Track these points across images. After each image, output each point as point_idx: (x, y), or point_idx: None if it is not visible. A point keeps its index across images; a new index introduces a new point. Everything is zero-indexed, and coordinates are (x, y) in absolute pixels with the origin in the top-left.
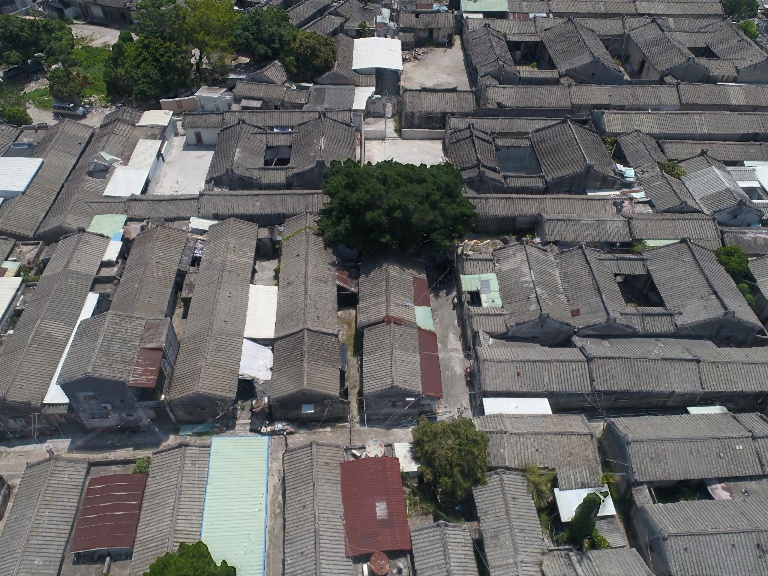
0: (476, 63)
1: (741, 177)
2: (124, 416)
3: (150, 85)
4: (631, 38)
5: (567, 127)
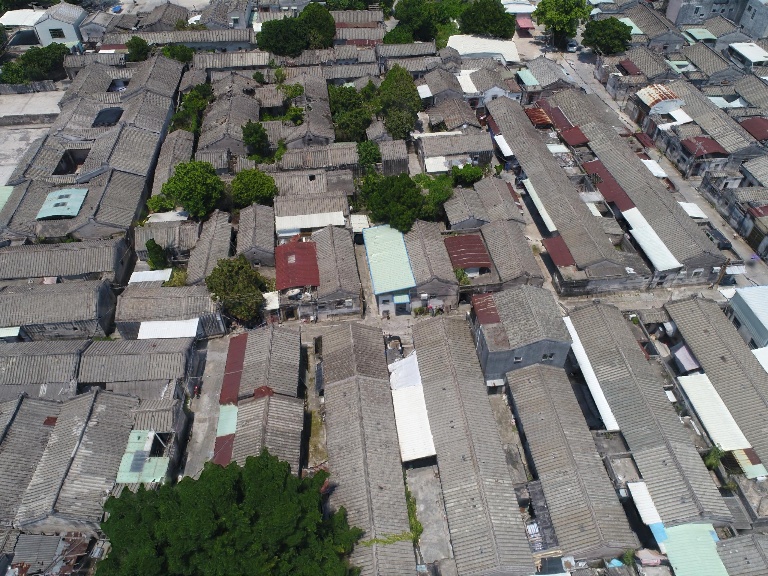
0: None
1: None
2: None
3: None
4: None
5: None
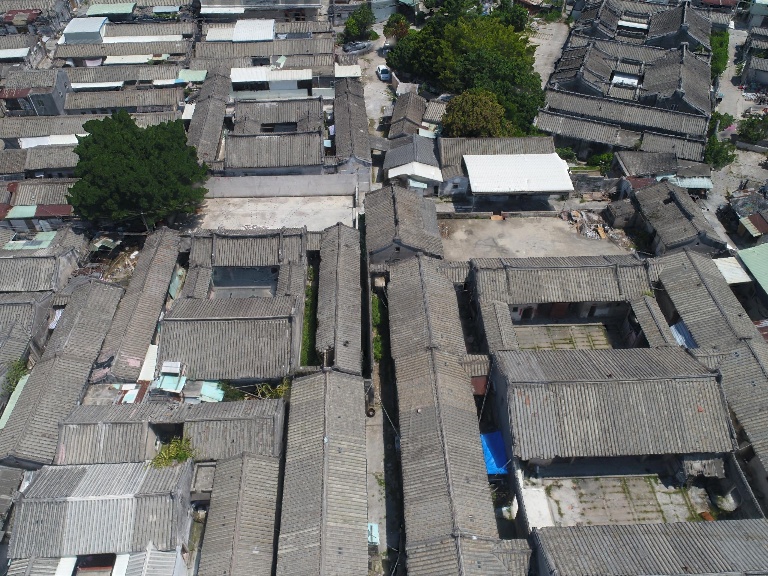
0: None
1: (131, 573)
2: None
3: (397, 57)
4: None
5: None
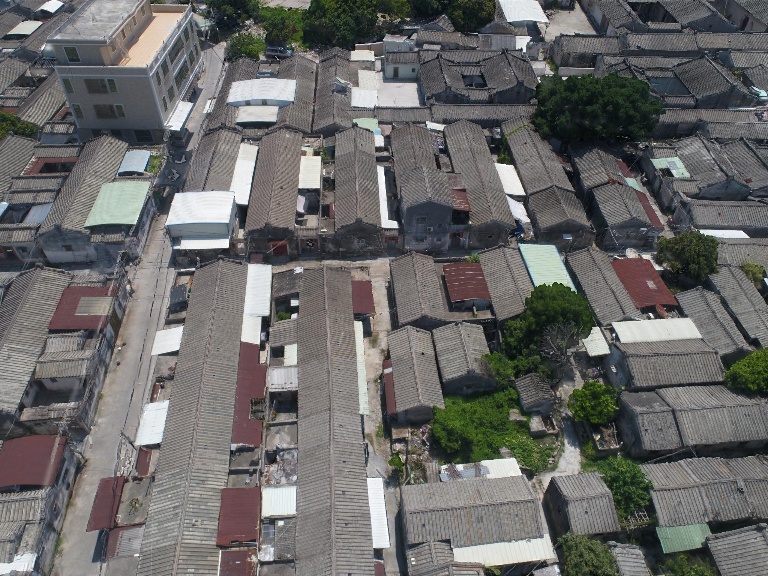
0: (609, 18)
1: None
2: (435, 240)
3: (349, 32)
4: (734, 0)
5: (705, 61)
